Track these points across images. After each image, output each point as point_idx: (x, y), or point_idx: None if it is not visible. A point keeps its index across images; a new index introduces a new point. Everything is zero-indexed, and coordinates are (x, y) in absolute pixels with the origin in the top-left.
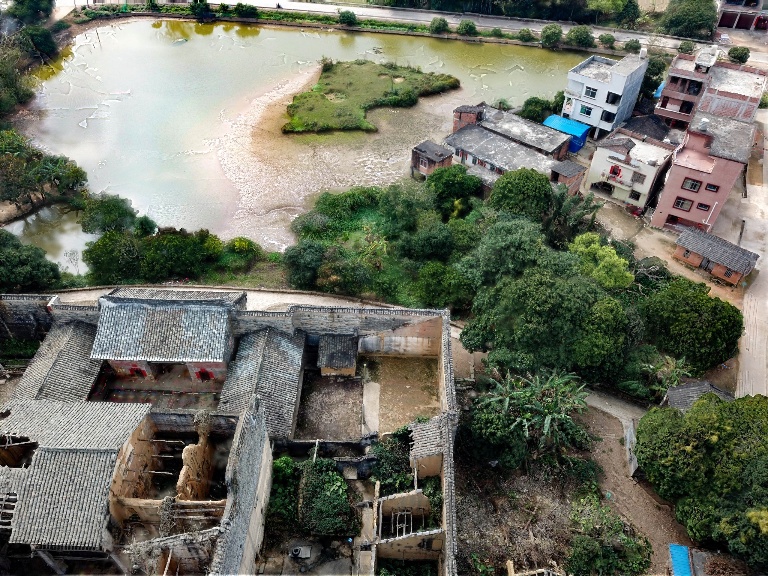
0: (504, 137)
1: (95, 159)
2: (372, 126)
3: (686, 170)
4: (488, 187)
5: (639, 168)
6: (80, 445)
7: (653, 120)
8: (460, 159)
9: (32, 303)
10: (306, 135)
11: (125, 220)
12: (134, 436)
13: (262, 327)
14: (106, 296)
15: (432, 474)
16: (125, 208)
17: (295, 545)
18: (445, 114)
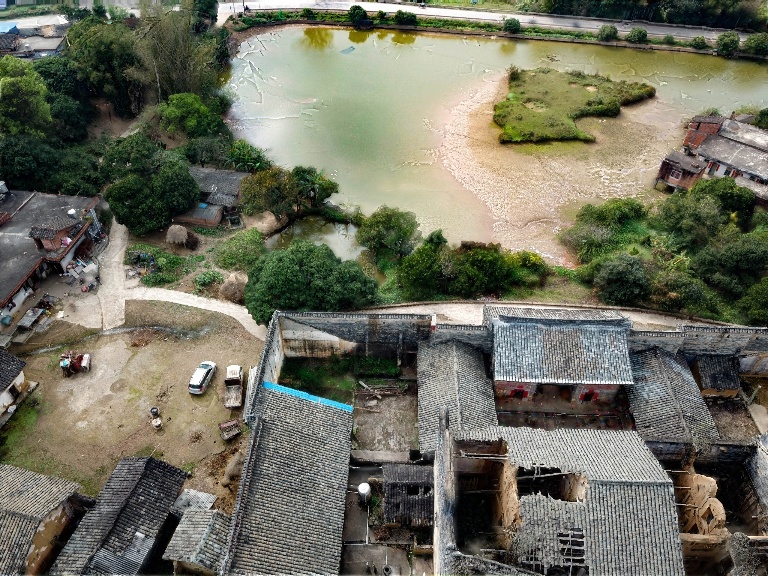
0: None
1: None
2: (590, 136)
3: None
4: (764, 200)
5: None
6: (627, 477)
7: None
8: (708, 170)
9: (407, 322)
10: (524, 145)
11: (413, 234)
12: None
13: (648, 347)
14: (501, 316)
15: None
16: None
17: None
18: (654, 123)
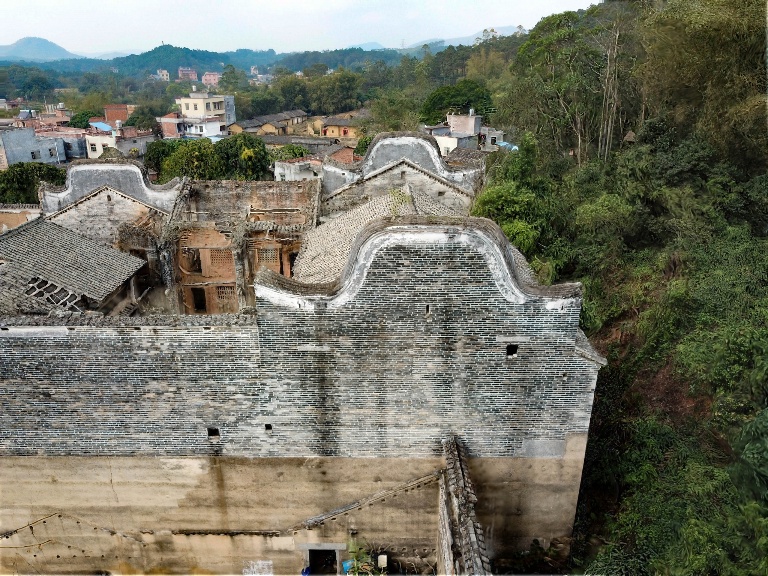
0: None
1: None
2: None
3: None
4: None
5: None
6: None
7: None
8: None
9: None
10: None
11: None
12: None
13: None
14: None
15: None
16: None
17: None
18: None
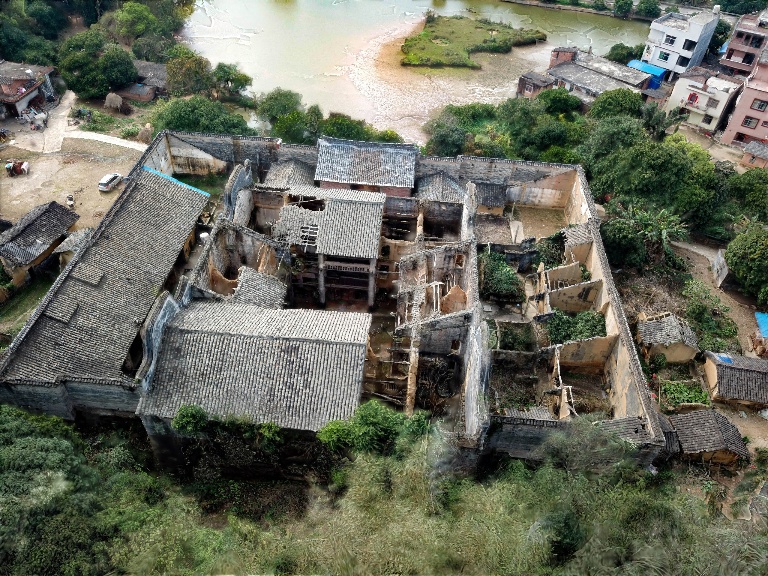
0: (596, 72)
1: (248, 74)
2: (477, 64)
3: (756, 92)
4: (587, 105)
5: (714, 94)
6: None
7: (720, 68)
8: None
9: (261, 144)
10: (421, 68)
11: (298, 109)
12: None
13: (436, 172)
14: (325, 137)
15: None
16: (300, 99)
17: None
18: (536, 60)
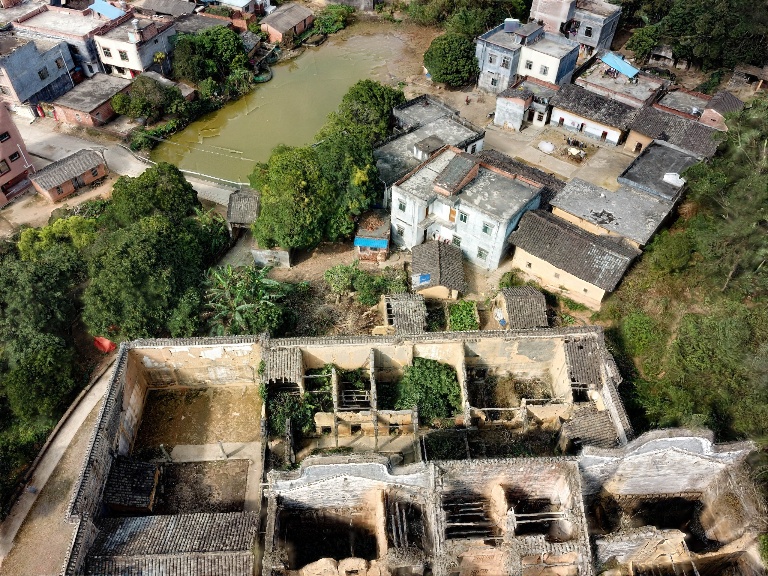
0: None
1: None
2: None
3: None
4: None
5: None
6: None
7: None
8: None
9: None
10: None
11: None
12: None
13: (83, 569)
14: None
15: None
16: None
17: None
18: None
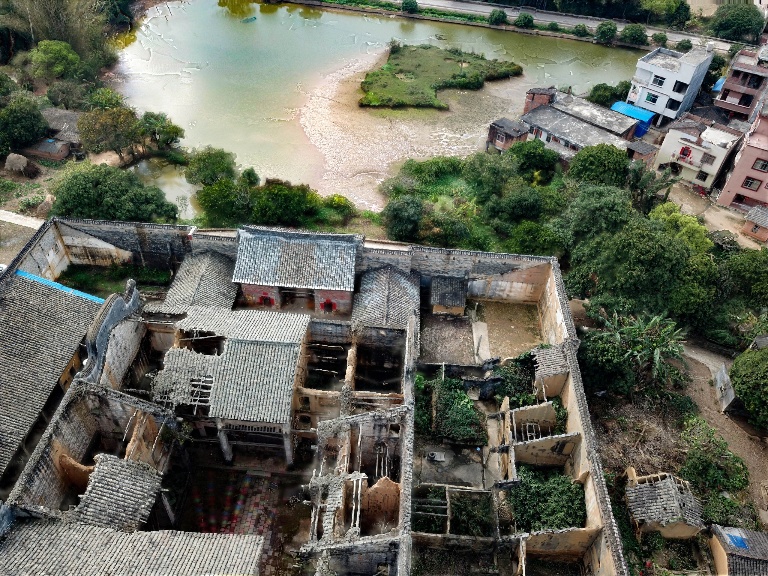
0: (576, 118)
1: (184, 120)
2: (444, 104)
3: (758, 151)
4: (566, 161)
5: (710, 149)
6: (264, 339)
7: (714, 111)
8: (534, 137)
9: (171, 233)
10: (382, 109)
11: (231, 172)
12: (302, 339)
13: (383, 265)
14: (246, 227)
15: (552, 395)
16: (232, 160)
17: (430, 450)
18: (511, 98)
